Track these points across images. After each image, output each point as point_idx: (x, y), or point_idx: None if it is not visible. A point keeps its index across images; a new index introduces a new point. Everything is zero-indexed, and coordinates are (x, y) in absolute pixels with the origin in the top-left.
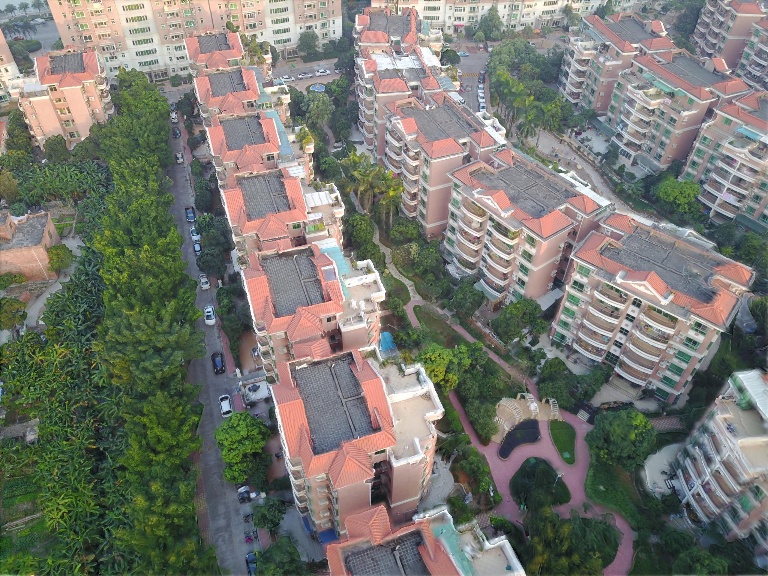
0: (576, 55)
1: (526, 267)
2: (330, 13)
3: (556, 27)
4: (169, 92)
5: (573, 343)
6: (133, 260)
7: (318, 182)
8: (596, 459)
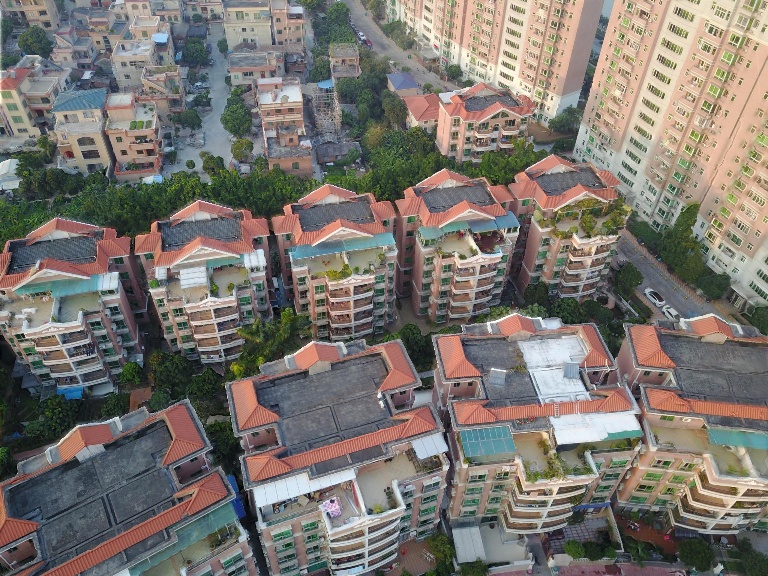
0: None
1: None
2: None
3: None
4: None
5: None
6: None
7: (241, 284)
8: None
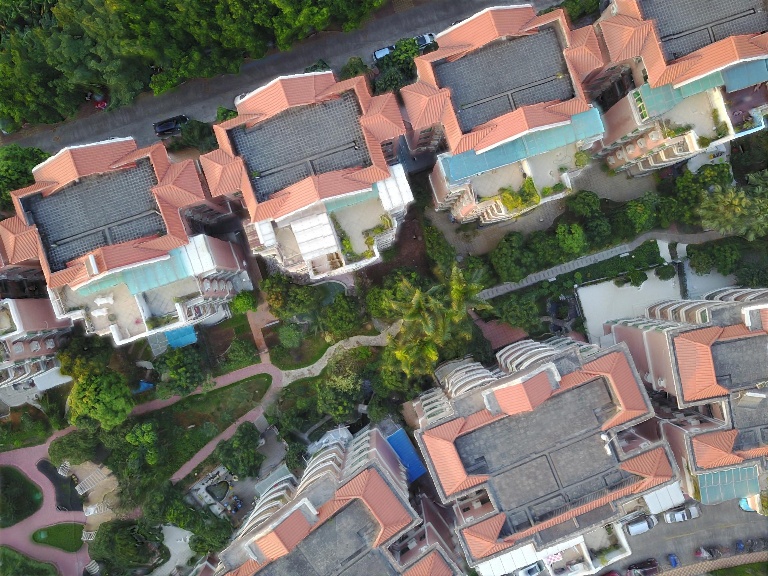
0: None
1: None
2: None
3: None
4: None
5: None
6: None
7: (381, 231)
8: (33, 567)
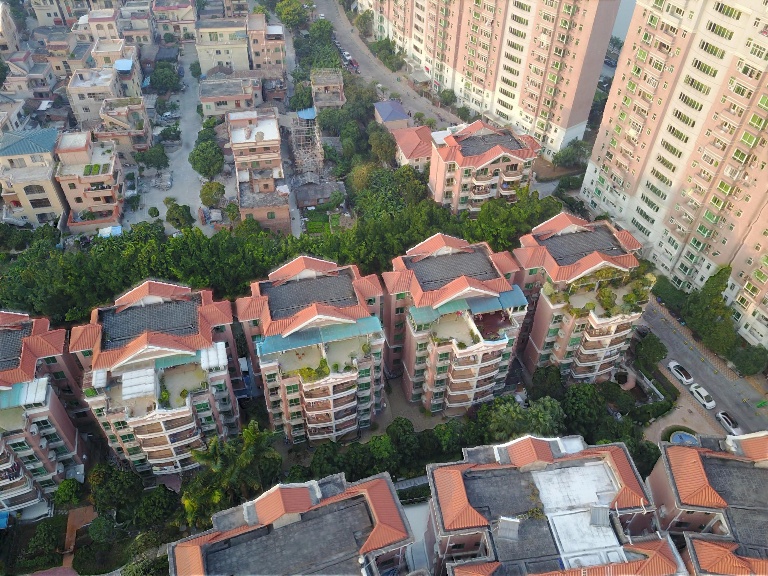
0: None
1: None
2: None
3: None
4: None
5: None
6: None
7: (196, 389)
8: None
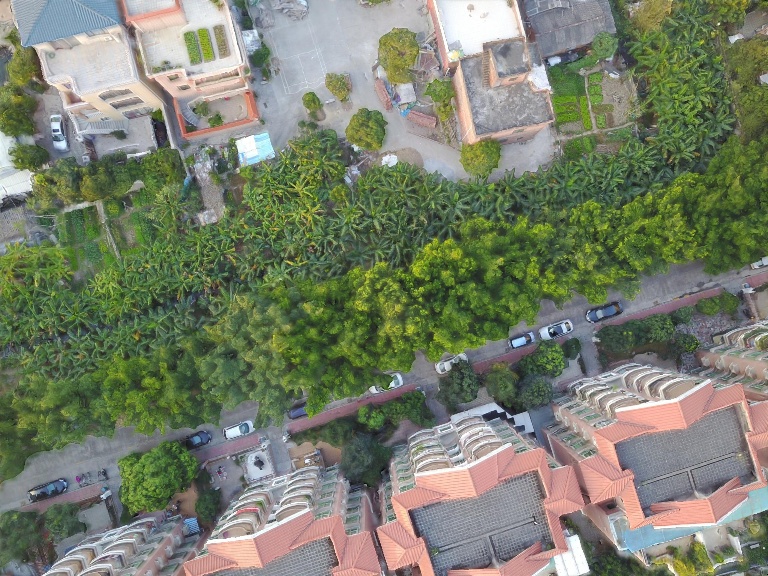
0: None
1: None
2: None
3: None
4: None
5: None
6: (388, 313)
7: None
8: None
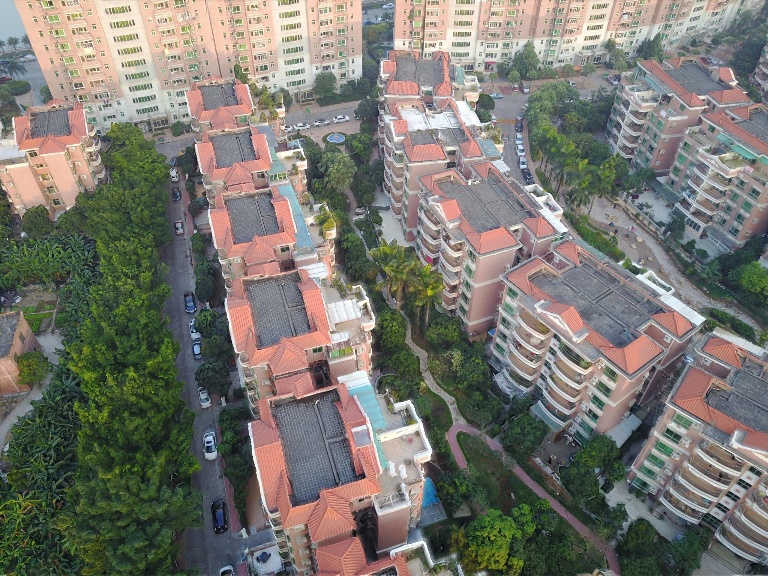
0: (631, 106)
1: (601, 401)
2: (349, 52)
3: (597, 63)
4: (170, 143)
5: (660, 497)
6: (115, 392)
7: (342, 283)
8: None
